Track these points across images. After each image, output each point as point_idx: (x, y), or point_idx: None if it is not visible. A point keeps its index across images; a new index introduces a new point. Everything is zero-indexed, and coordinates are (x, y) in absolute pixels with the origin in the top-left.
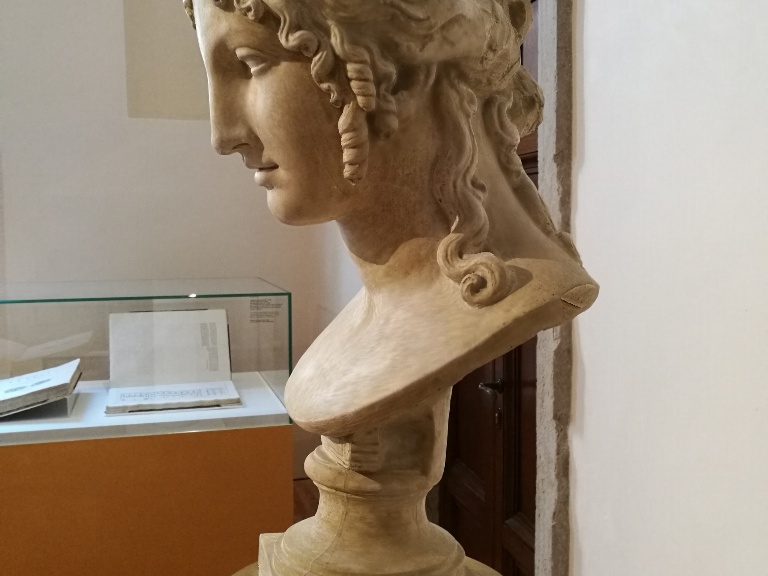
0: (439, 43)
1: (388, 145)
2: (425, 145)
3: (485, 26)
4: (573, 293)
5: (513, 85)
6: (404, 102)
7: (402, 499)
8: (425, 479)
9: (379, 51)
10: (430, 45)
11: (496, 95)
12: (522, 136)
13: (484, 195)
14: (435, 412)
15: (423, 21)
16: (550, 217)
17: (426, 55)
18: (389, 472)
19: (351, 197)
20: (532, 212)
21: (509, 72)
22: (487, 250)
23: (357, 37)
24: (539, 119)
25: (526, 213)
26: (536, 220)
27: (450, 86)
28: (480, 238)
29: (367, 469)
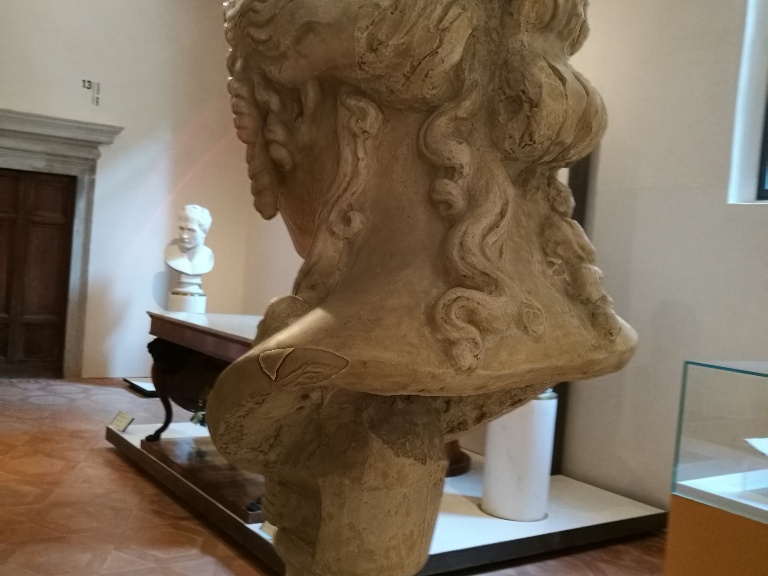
0: (295, 60)
1: (306, 176)
2: (329, 174)
3: (357, 24)
4: (472, 383)
5: (498, 84)
6: (299, 129)
7: (298, 573)
8: (311, 561)
9: (262, 82)
10: (287, 64)
11: (446, 103)
12: (535, 153)
13: (346, 230)
14: (324, 486)
15: (268, 42)
16: (477, 267)
17: (286, 76)
18: (289, 534)
19: (307, 233)
20: (443, 257)
21: (416, 71)
22: (327, 296)
23: (250, 72)
24: (531, 126)
25: (437, 259)
26: (446, 269)
27: (341, 103)
28: (311, 279)
29: (266, 518)
